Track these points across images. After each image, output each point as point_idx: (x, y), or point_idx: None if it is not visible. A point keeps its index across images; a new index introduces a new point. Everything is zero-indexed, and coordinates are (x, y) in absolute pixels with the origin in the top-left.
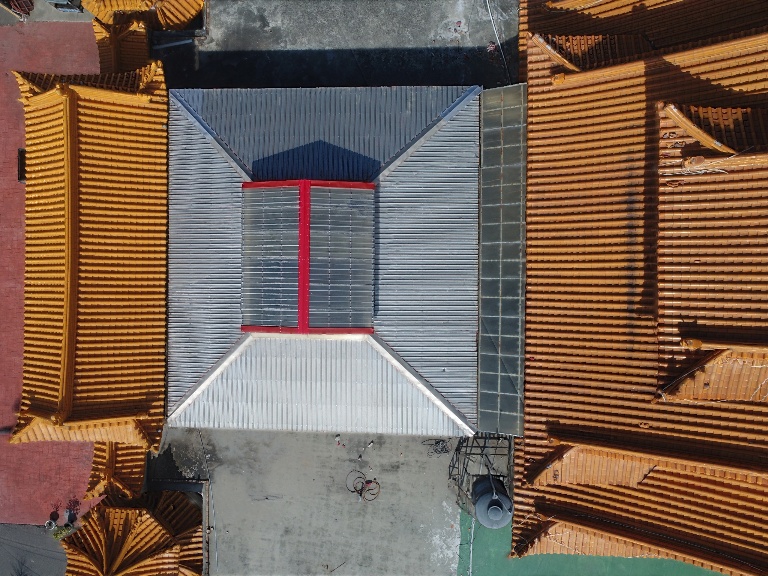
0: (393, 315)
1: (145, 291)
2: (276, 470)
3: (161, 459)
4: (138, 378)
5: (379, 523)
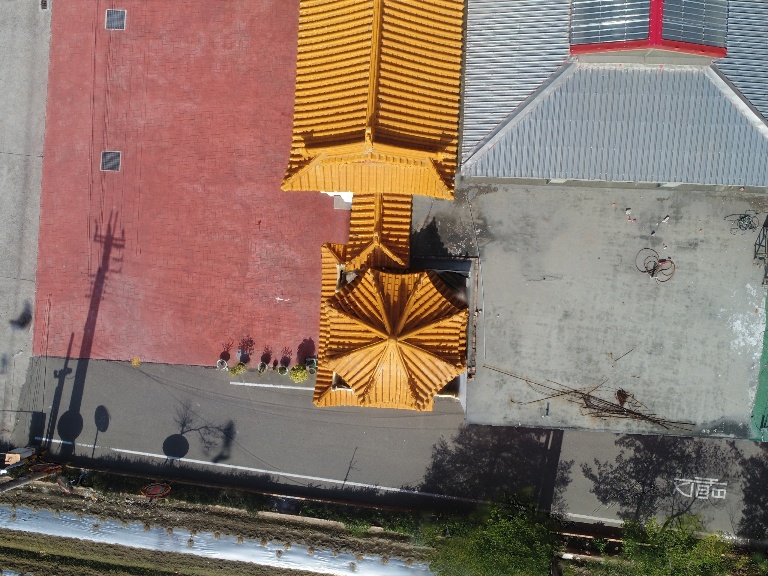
0: (735, 46)
1: (442, 21)
2: (556, 247)
3: (424, 234)
4: (433, 116)
5: (673, 307)
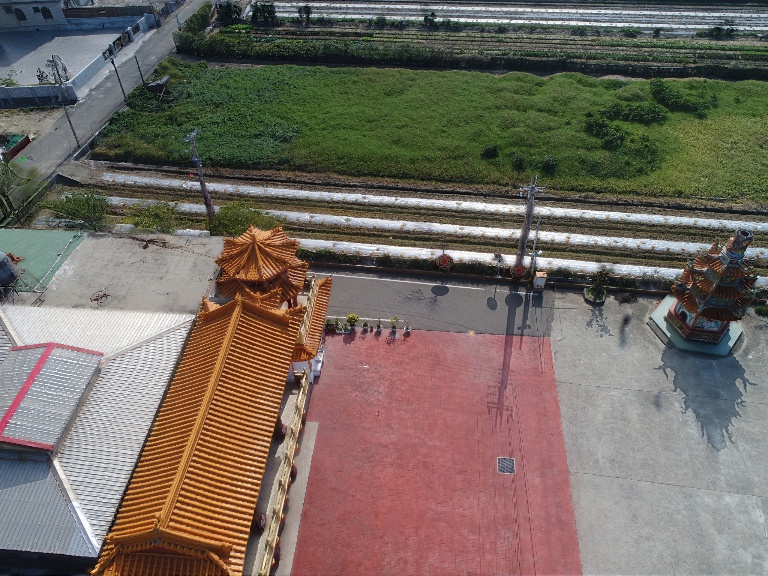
0: None
1: None
2: (155, 307)
3: None
4: None
5: (101, 281)
